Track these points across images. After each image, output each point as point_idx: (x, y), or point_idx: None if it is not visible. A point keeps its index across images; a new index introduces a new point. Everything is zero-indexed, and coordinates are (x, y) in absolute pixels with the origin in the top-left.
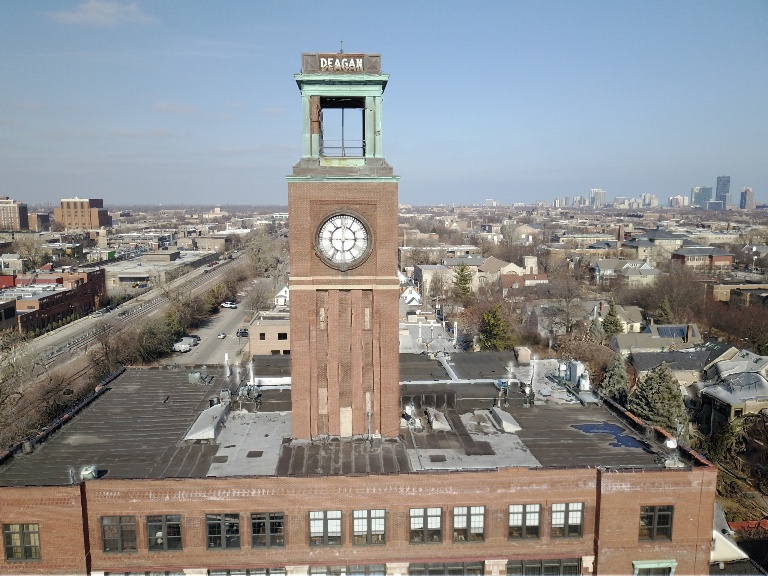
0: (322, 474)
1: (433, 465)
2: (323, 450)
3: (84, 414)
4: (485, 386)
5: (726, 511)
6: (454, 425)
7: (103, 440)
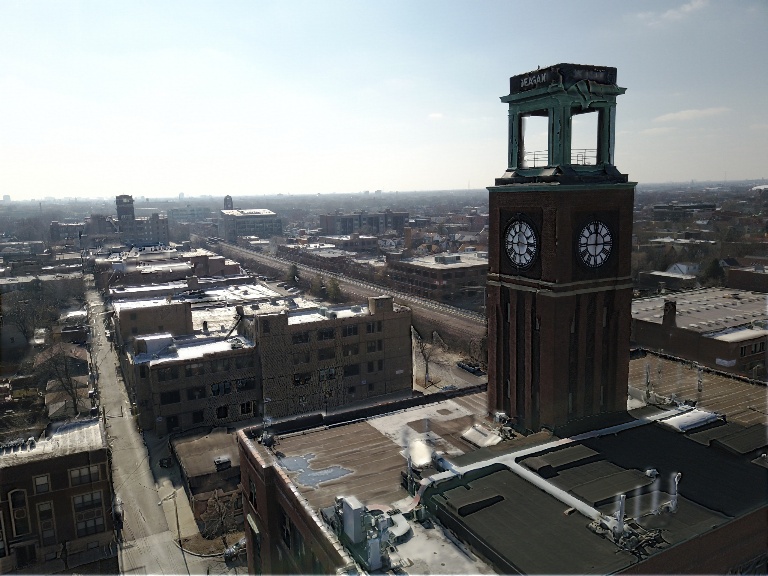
0: None
1: (442, 405)
2: None
3: (762, 389)
4: None
5: None
6: (466, 444)
7: (682, 382)
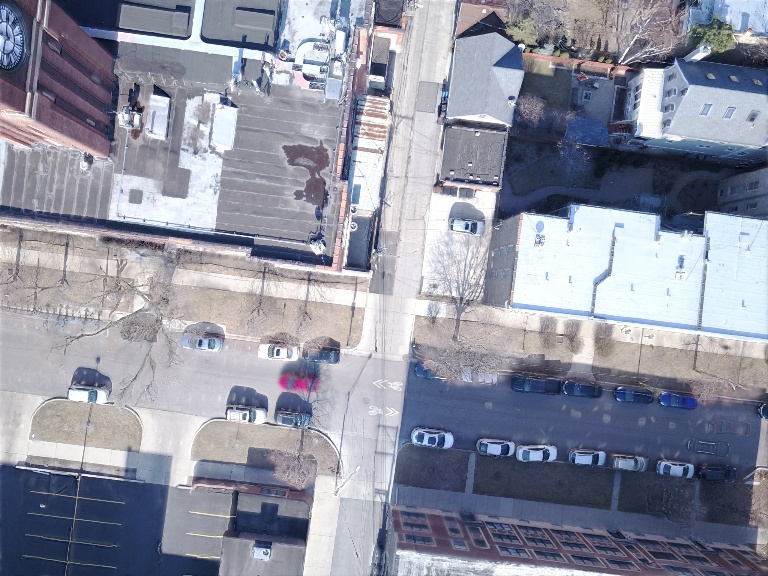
0: (32, 221)
1: (127, 210)
2: (41, 164)
3: None
4: (223, 60)
5: (578, 27)
6: (173, 126)
7: None
